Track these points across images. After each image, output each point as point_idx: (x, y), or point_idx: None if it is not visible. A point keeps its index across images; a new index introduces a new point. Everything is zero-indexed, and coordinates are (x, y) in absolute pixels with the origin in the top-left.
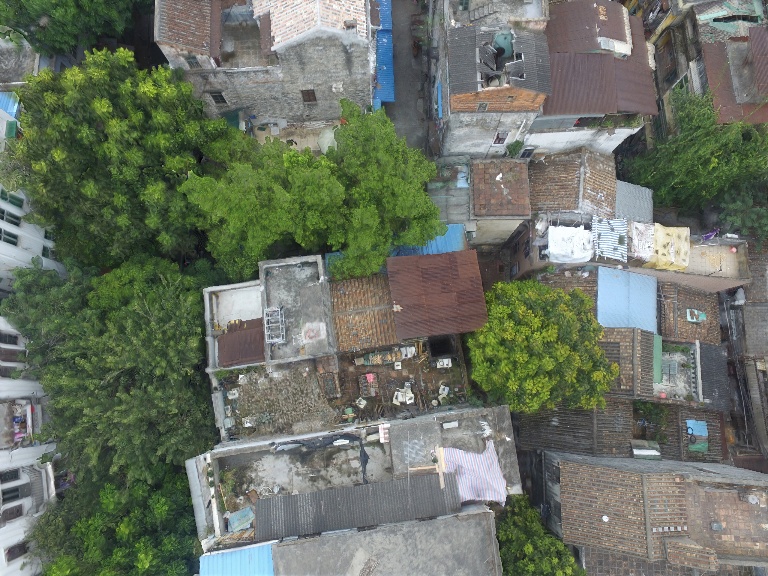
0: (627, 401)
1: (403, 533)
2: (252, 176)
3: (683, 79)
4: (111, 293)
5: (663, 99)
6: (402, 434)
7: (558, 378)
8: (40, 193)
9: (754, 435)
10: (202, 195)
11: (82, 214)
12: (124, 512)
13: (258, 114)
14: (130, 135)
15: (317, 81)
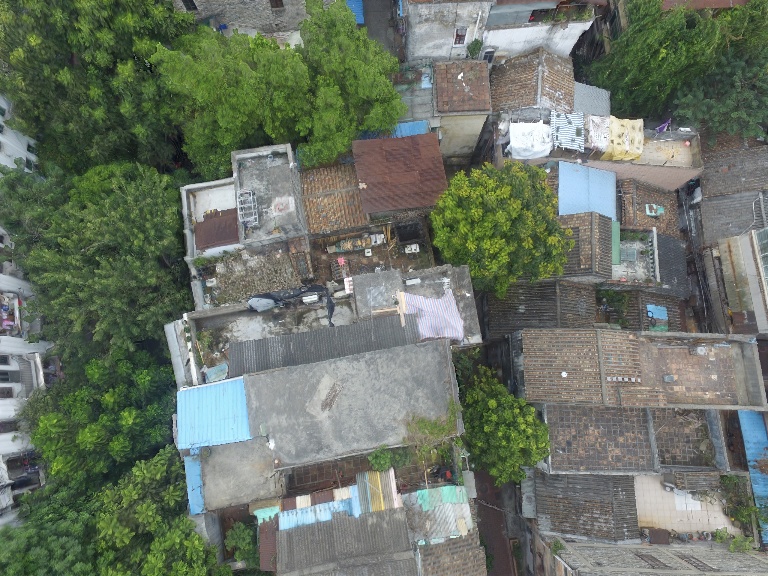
0: (590, 287)
1: (365, 360)
2: (218, 52)
3: None
4: (91, 187)
5: (618, 6)
6: (365, 282)
7: (516, 245)
8: (19, 86)
9: (713, 322)
10: (170, 65)
11: (62, 120)
12: (109, 387)
13: (229, 23)
14: (101, 14)
15: None
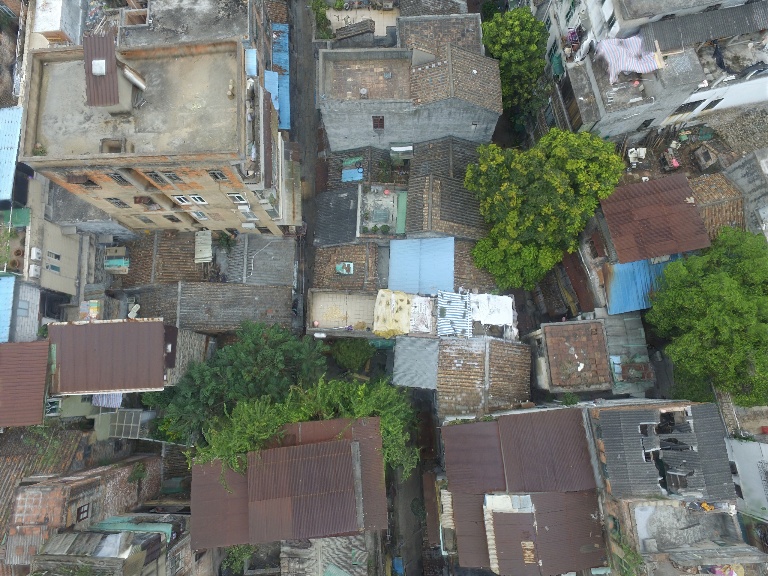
0: None
1: (692, 2)
2: None
3: None
4: None
5: None
6: (694, 75)
7: None
8: None
9: None
10: None
11: None
12: None
13: None
14: None
15: None
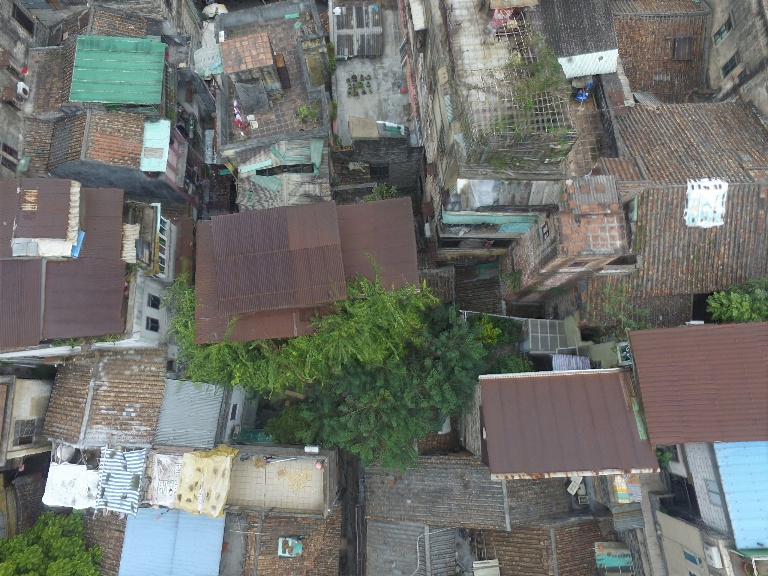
0: None
1: None
2: None
3: None
4: None
5: None
6: None
7: None
8: None
9: None
10: None
11: None
12: None
13: None
14: None
15: None
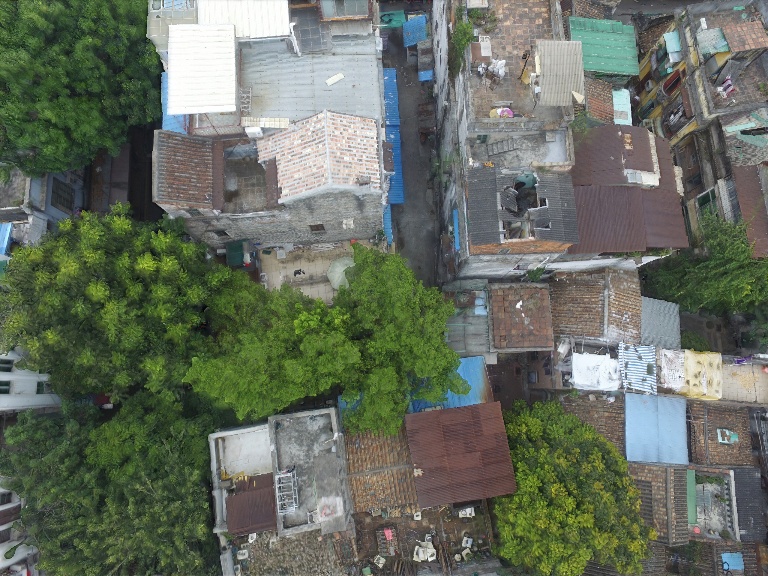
0: None
1: None
2: (261, 353)
3: (710, 193)
4: (111, 451)
5: (687, 206)
6: None
7: None
8: (33, 357)
9: None
10: (208, 385)
11: None
12: None
13: (263, 242)
14: (129, 315)
15: (326, 219)
